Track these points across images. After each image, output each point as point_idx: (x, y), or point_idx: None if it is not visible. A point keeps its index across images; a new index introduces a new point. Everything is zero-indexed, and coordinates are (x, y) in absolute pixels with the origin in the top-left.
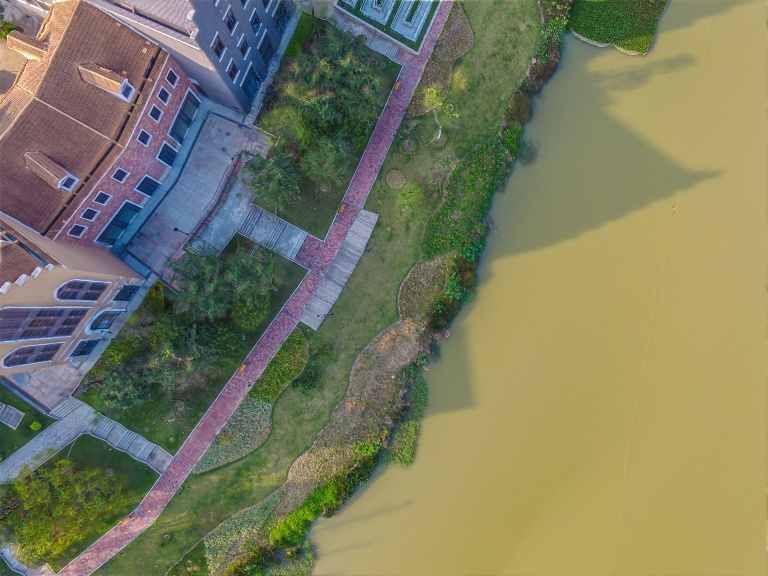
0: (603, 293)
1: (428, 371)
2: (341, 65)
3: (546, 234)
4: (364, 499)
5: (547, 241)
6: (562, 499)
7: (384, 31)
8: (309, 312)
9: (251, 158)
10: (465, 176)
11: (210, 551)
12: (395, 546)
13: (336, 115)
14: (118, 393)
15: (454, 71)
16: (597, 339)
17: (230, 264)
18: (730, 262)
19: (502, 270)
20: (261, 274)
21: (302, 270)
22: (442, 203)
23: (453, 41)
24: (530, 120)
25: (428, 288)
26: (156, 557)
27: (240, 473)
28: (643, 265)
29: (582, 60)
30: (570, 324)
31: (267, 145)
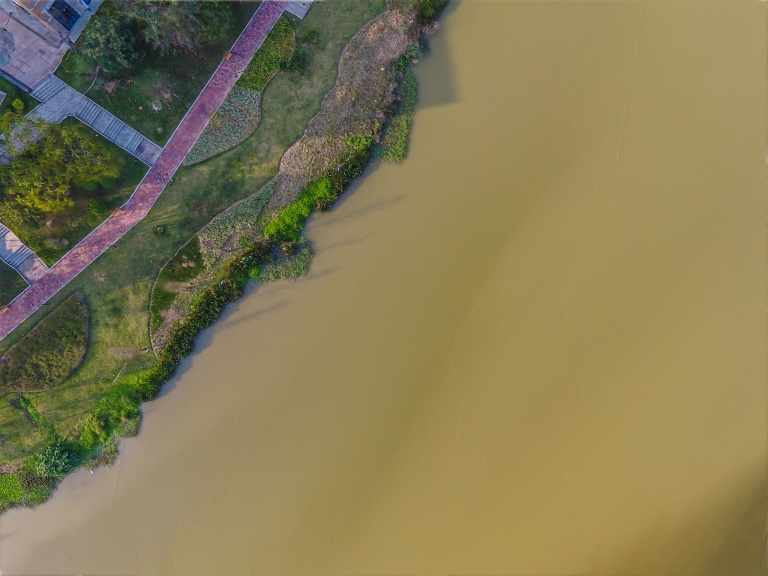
0: None
1: (418, 63)
2: None
3: None
4: (358, 194)
5: None
6: (556, 189)
7: None
8: (294, 0)
9: None
10: None
11: (205, 245)
12: (391, 240)
13: None
14: (100, 36)
15: None
16: (587, 29)
17: None
18: None
19: None
20: None
21: None
22: None
23: None
24: None
25: None
26: (150, 251)
27: (231, 164)
28: None
29: None
30: (560, 15)
31: None
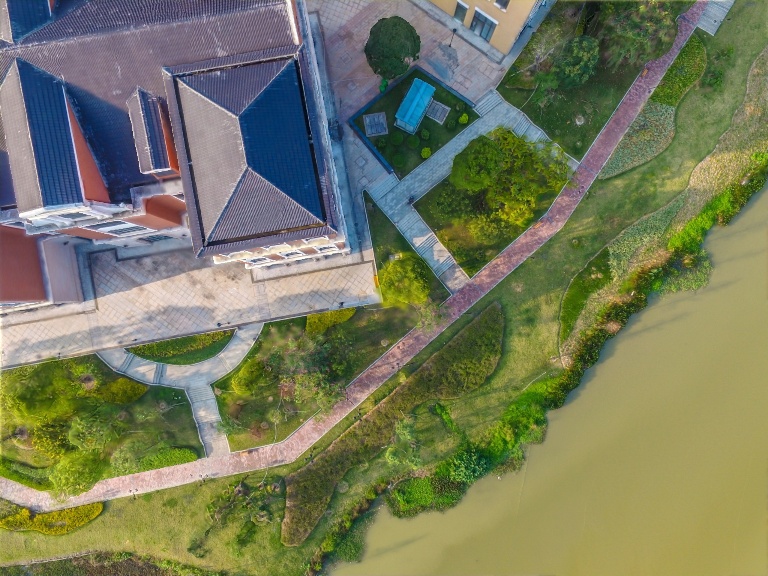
0: None
1: None
2: None
3: None
4: (757, 208)
5: None
6: None
7: None
8: (706, 18)
9: None
10: None
11: (614, 257)
12: None
13: None
14: (586, 54)
15: None
16: None
17: None
18: None
19: None
20: None
21: None
22: None
23: None
24: None
25: None
26: (564, 262)
27: (645, 177)
28: None
29: None
30: None
31: None
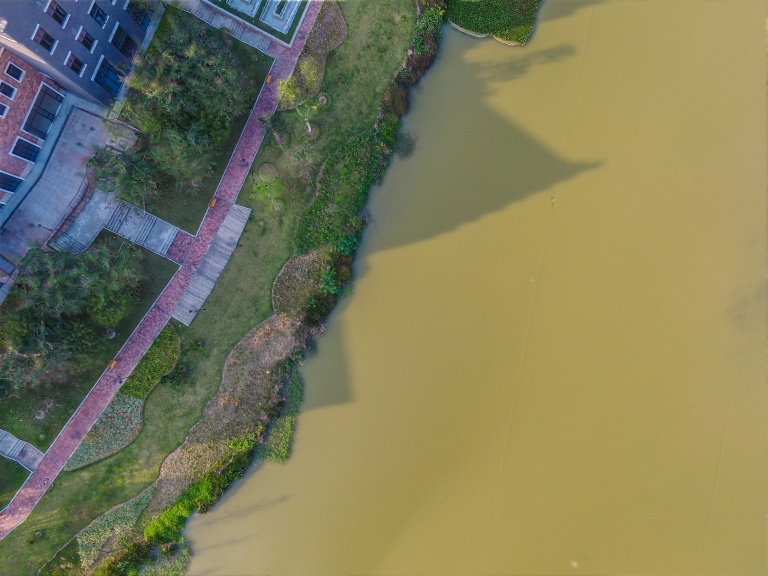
0: (480, 286)
1: (303, 366)
2: (185, 57)
3: (424, 227)
4: (240, 495)
5: (425, 234)
6: (439, 493)
7: (253, 23)
8: (181, 308)
9: (116, 153)
10: (339, 169)
11: (83, 548)
12: (271, 541)
13: (189, 108)
14: None
15: (327, 63)
16: (475, 332)
17: (77, 260)
18: (610, 253)
19: (379, 264)
20: (110, 269)
21: (173, 265)
22: (315, 197)
23: (326, 33)
24: (407, 112)
25: (303, 282)
26: (28, 554)
27: (111, 470)
28: (521, 257)
29: (460, 51)
30: (448, 317)
31: (132, 140)
